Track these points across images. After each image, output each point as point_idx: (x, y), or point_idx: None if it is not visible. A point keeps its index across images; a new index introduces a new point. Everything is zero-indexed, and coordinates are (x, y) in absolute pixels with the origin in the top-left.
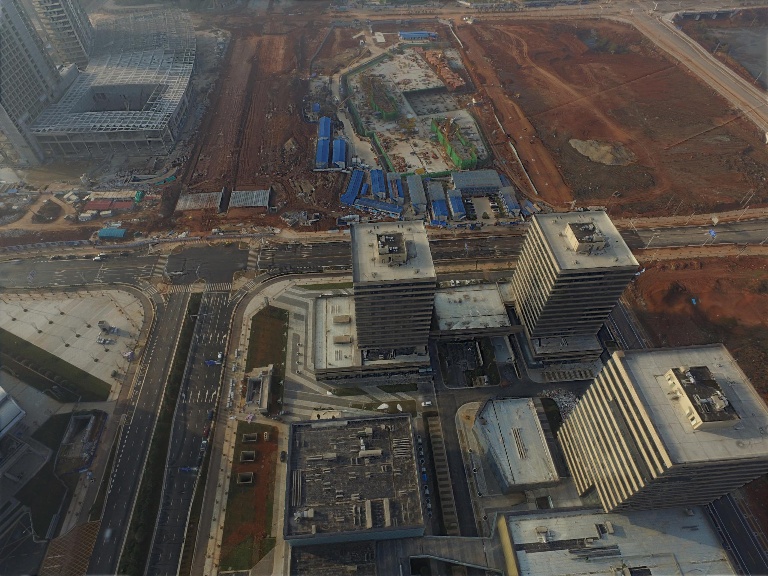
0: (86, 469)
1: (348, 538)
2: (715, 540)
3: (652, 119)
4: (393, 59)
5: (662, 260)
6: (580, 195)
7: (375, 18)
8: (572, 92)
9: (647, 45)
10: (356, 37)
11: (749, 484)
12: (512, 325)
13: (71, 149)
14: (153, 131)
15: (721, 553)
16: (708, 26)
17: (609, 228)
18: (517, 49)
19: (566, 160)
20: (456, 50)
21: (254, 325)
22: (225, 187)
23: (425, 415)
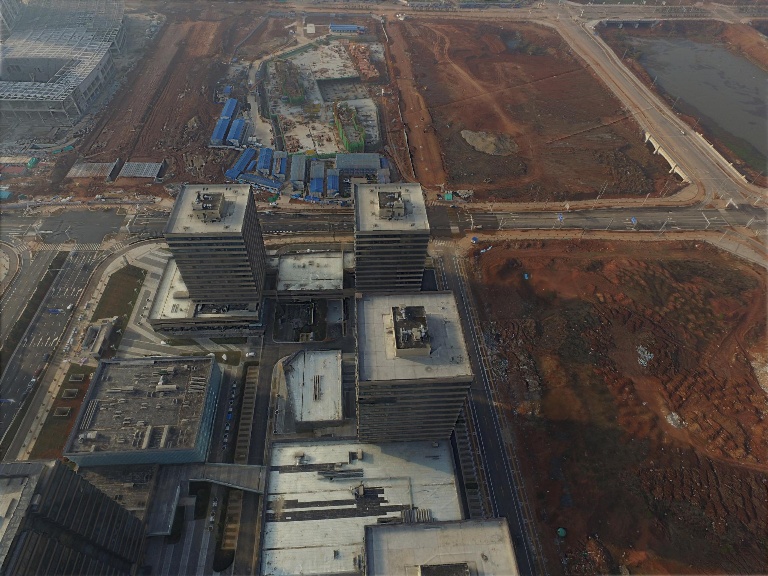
0: None
1: (129, 459)
2: (450, 467)
3: (545, 115)
4: (317, 49)
5: (510, 240)
6: (454, 180)
7: (311, 10)
8: (478, 88)
9: (564, 48)
10: (288, 27)
11: (522, 431)
12: (344, 288)
13: None
14: (59, 103)
15: (452, 478)
16: (628, 34)
17: (419, 198)
18: (439, 46)
19: (451, 148)
20: (382, 44)
21: (110, 281)
22: (120, 158)
23: (246, 364)
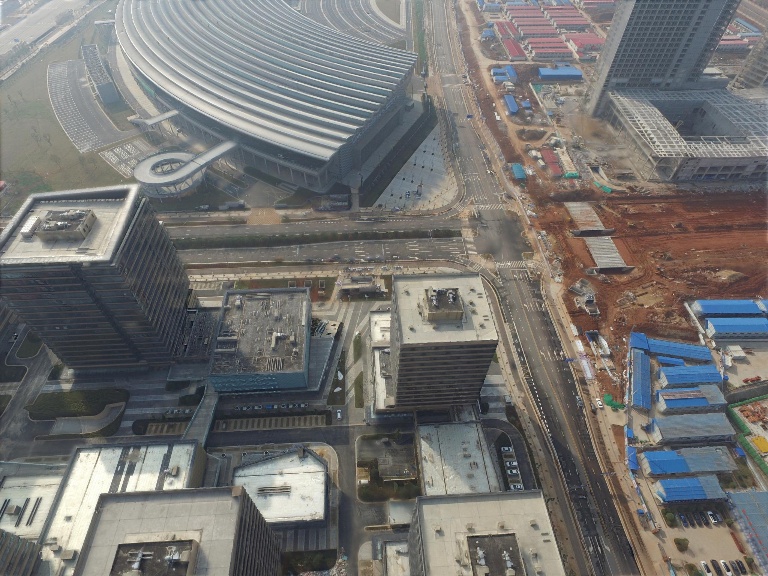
0: (313, 210)
1: None
2: None
3: None
4: None
5: None
6: None
7: None
8: None
9: None
10: None
11: None
12: None
13: None
14: (668, 158)
15: None
16: None
17: None
18: None
19: None
20: None
21: None
22: (615, 230)
23: (327, 412)
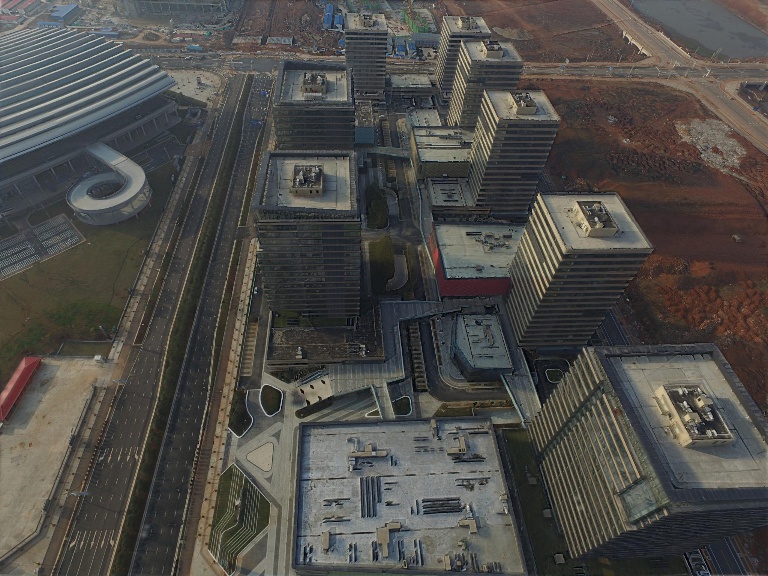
0: (201, 126)
1: None
2: None
3: (552, 21)
4: None
5: None
6: None
7: None
8: (503, 5)
9: None
10: None
11: None
12: None
13: (158, 10)
14: (214, 1)
15: None
16: None
17: (482, 23)
18: None
19: None
20: None
21: None
22: (263, 35)
23: None
